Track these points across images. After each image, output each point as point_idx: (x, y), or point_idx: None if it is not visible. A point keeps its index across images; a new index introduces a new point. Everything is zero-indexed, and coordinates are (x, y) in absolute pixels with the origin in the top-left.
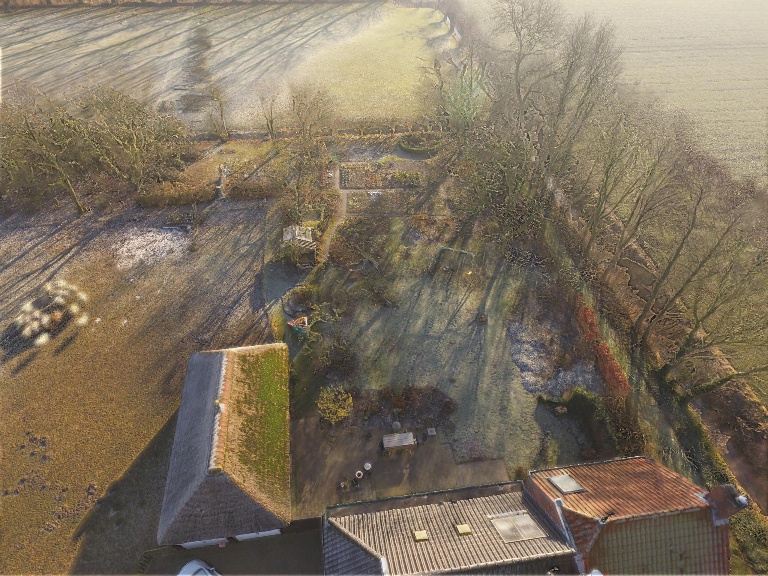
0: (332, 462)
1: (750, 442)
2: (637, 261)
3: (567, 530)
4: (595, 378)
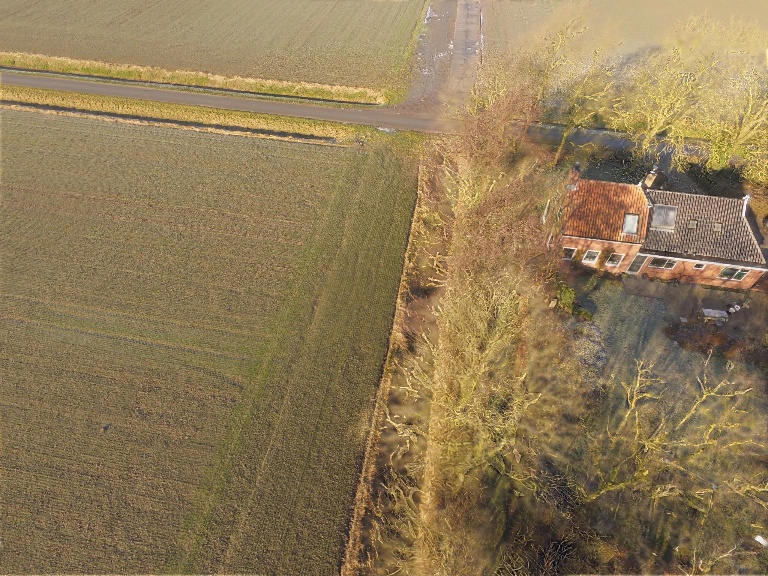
0: (761, 321)
1: (426, 273)
2: (386, 447)
3: (647, 198)
4: (534, 322)
